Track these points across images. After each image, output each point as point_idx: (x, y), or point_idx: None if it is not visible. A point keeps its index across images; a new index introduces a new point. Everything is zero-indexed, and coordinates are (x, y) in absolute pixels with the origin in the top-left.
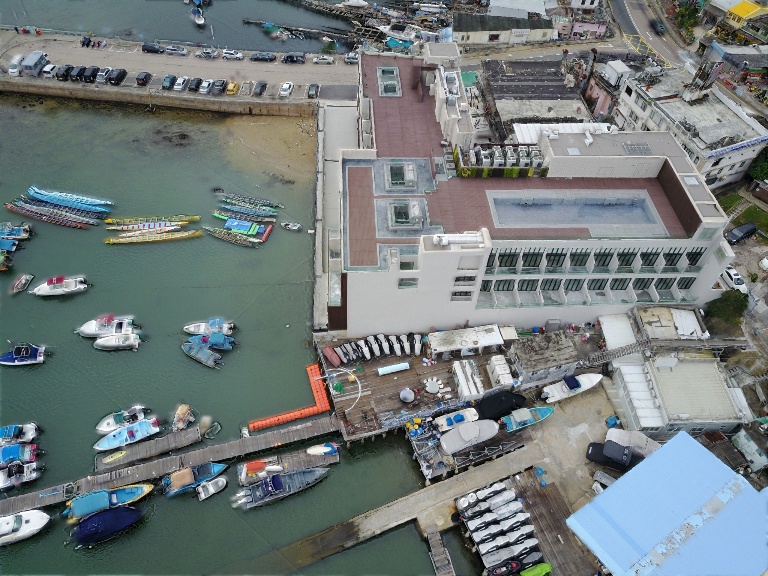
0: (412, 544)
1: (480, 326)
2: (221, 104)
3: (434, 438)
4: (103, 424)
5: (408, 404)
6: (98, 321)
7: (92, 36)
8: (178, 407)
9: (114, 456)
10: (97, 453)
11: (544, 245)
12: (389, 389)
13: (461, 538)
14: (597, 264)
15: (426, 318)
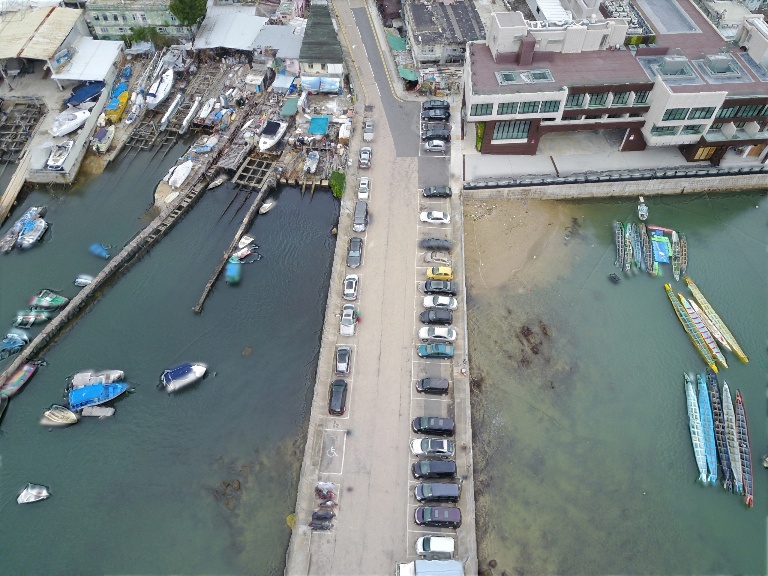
0: None
1: None
2: None
3: None
4: None
5: None
6: None
7: None
8: None
9: None
10: None
11: None
12: None
13: None
14: None
15: None
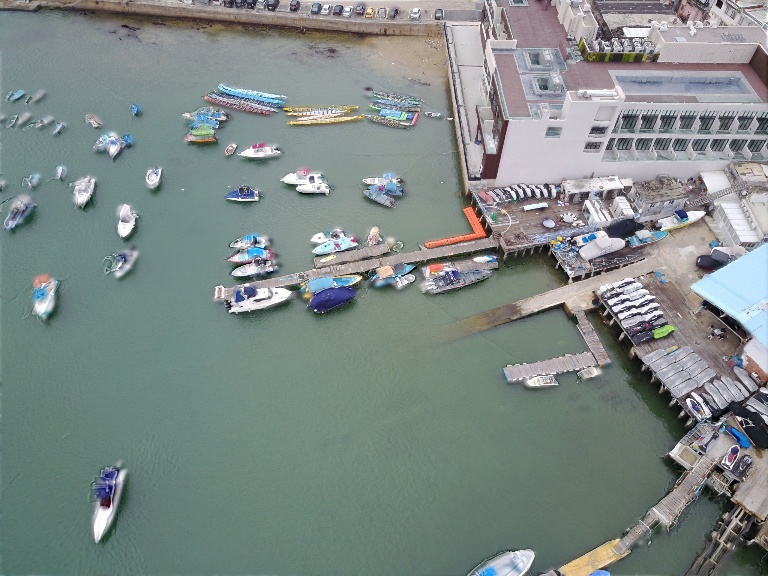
0: (561, 321)
1: (604, 177)
2: (361, 26)
3: (573, 251)
4: (316, 238)
5: (550, 229)
6: (298, 172)
7: None
8: (368, 232)
9: (328, 258)
10: (315, 256)
11: (660, 107)
12: (533, 220)
13: (599, 318)
14: (701, 127)
15: (560, 169)
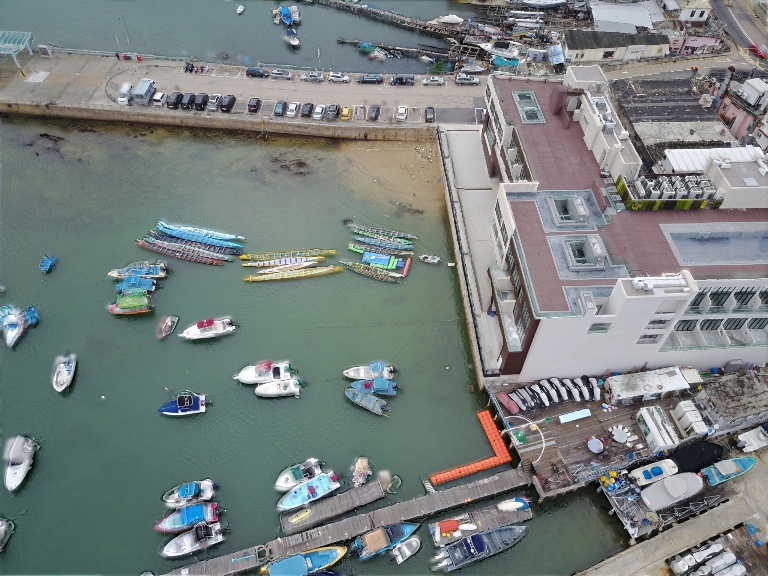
0: None
1: (660, 369)
2: (336, 130)
3: (633, 492)
4: (282, 479)
5: (598, 455)
6: (258, 367)
7: (193, 61)
8: (352, 459)
9: (300, 515)
10: (281, 511)
11: (735, 284)
12: (573, 438)
13: None
14: None
15: (604, 361)
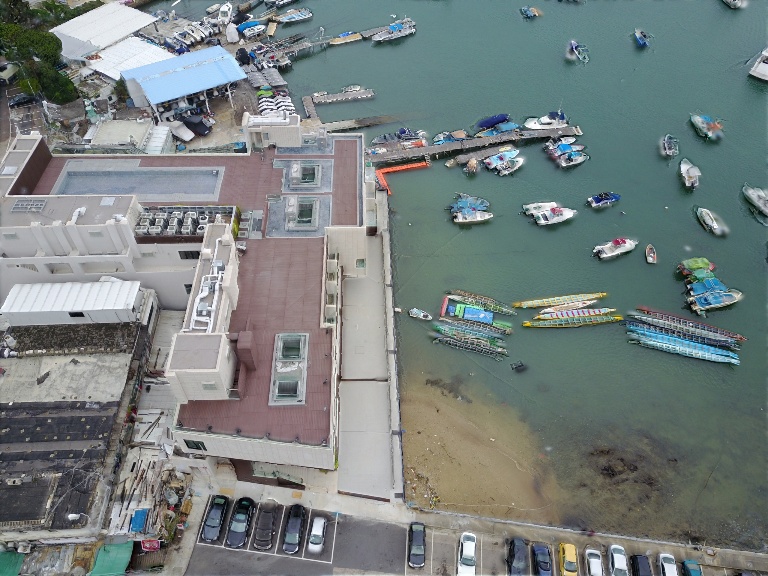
0: None
1: None
2: None
3: None
4: None
5: None
6: None
7: None
8: (477, 176)
9: (505, 149)
10: None
11: None
12: None
13: None
14: None
15: None
